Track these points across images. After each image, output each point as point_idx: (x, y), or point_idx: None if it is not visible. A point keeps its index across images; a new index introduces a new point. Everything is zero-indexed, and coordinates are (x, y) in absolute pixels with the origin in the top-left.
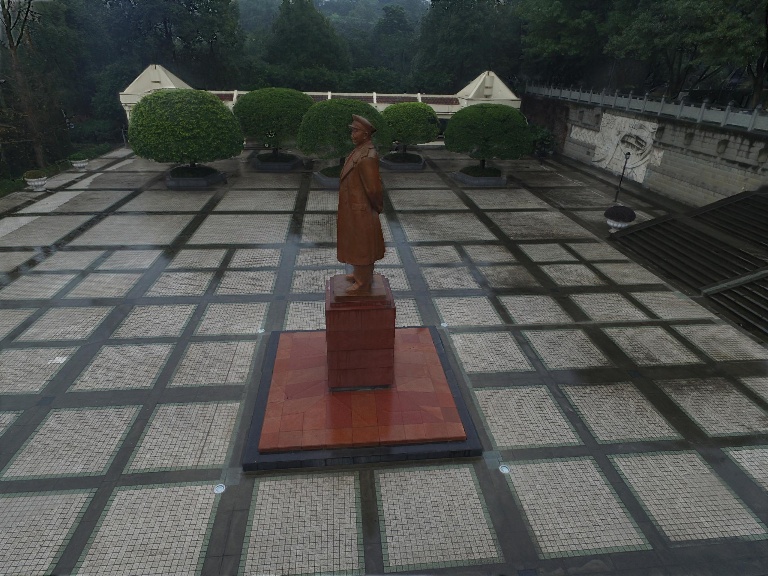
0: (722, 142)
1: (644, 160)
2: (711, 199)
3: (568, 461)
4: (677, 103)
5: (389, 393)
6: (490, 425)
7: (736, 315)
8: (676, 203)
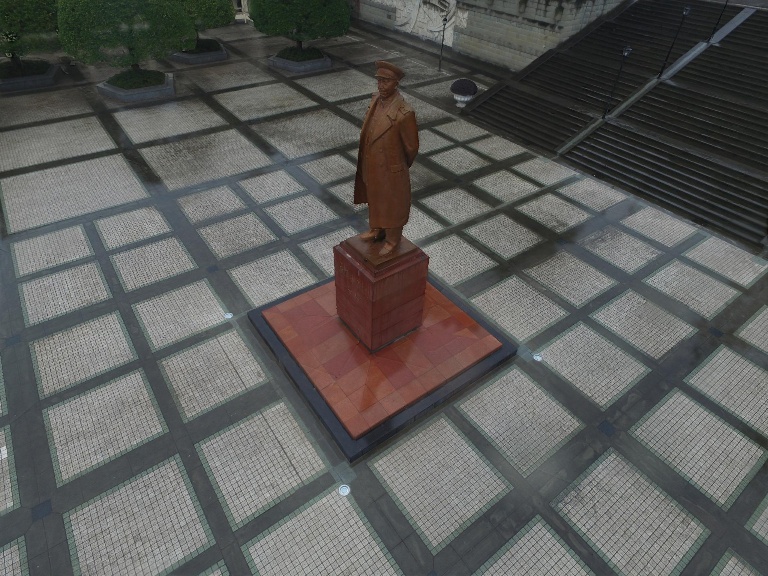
0: (523, 2)
1: (450, 22)
2: (518, 58)
3: (570, 331)
4: None
5: (421, 333)
6: (503, 326)
7: (588, 168)
8: (487, 65)
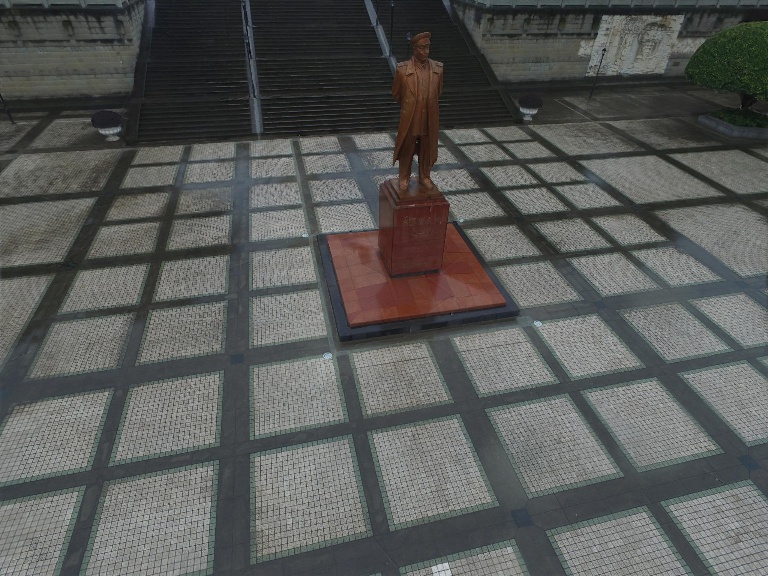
0: (67, 24)
1: None
2: (96, 82)
3: None
4: None
5: None
6: None
7: (290, 133)
8: (58, 100)
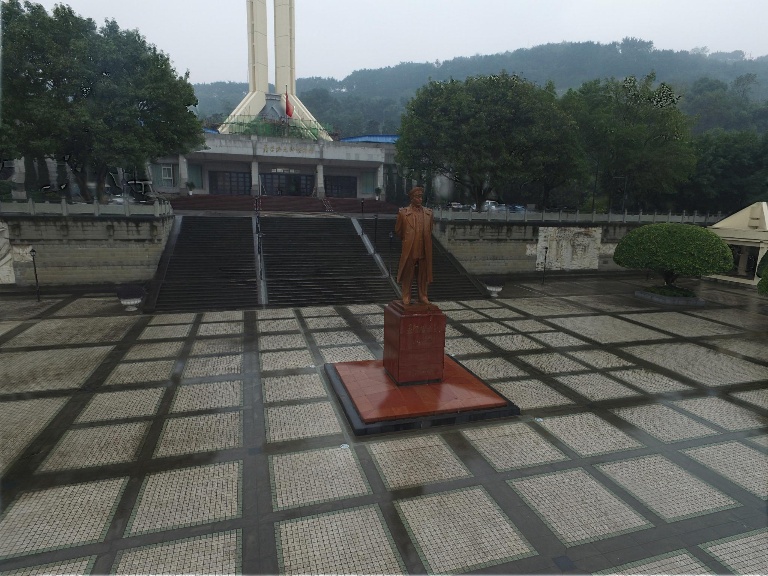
0: (110, 227)
1: (4, 260)
2: (121, 272)
3: None
4: (18, 201)
5: None
6: None
7: (291, 304)
8: (83, 286)
